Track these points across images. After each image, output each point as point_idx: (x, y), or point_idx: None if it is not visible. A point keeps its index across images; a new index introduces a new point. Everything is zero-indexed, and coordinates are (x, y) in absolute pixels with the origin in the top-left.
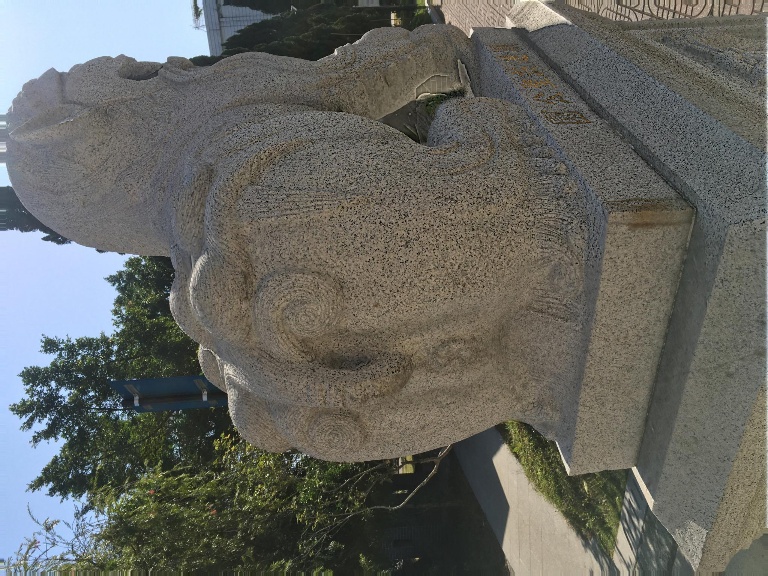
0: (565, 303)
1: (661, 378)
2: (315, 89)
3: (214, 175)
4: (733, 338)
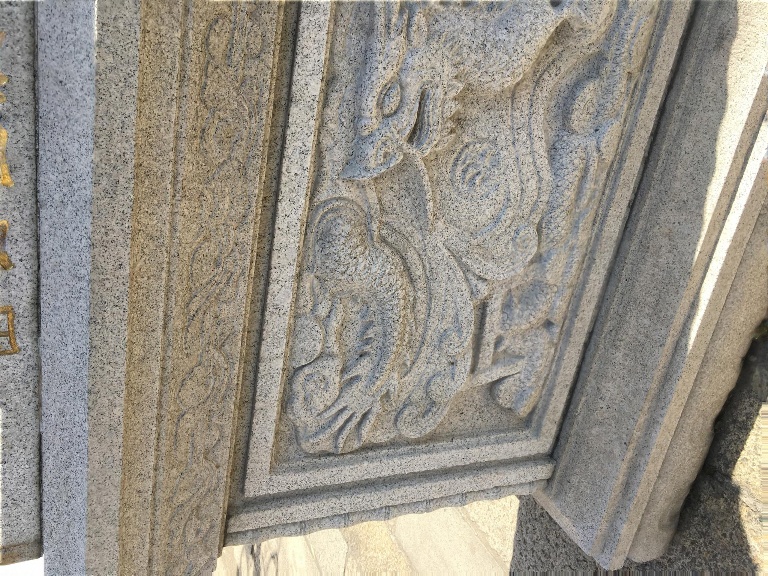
0: None
1: None
2: None
3: None
4: None
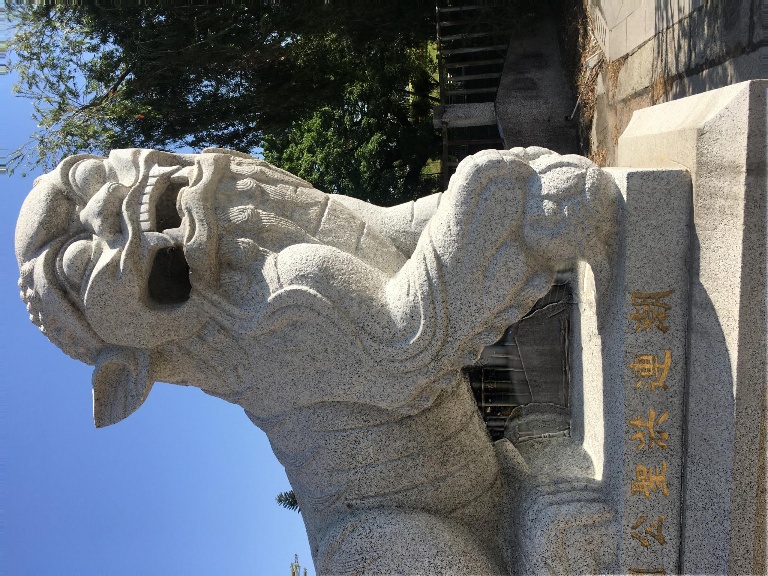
0: None
1: None
2: (404, 404)
3: None
4: None
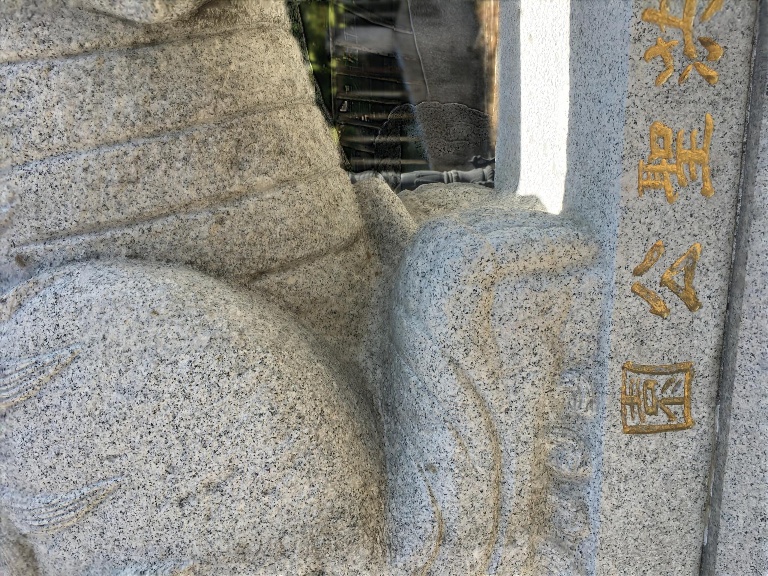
0: None
1: None
2: None
3: (42, 571)
4: None
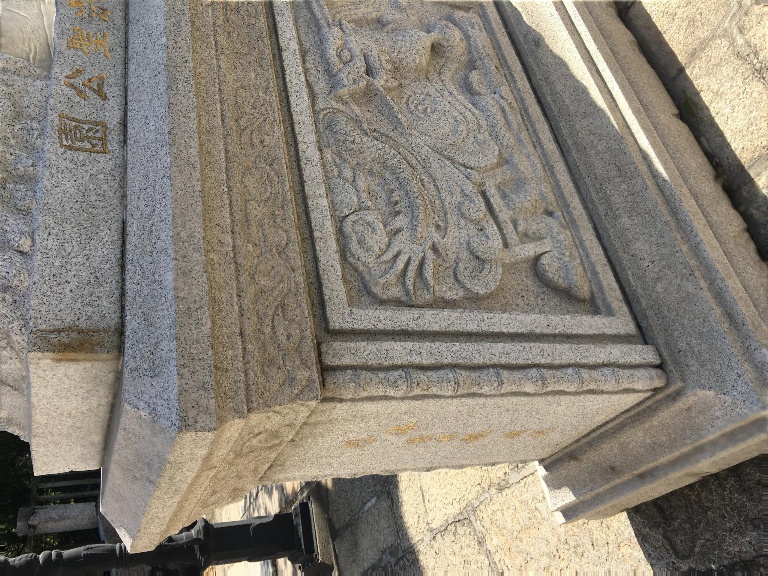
0: (13, 376)
1: (109, 435)
2: None
3: None
4: (135, 462)
